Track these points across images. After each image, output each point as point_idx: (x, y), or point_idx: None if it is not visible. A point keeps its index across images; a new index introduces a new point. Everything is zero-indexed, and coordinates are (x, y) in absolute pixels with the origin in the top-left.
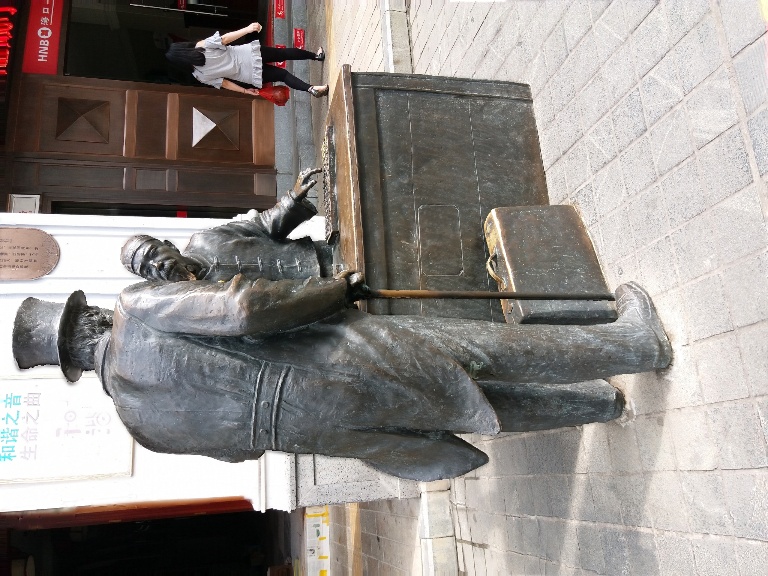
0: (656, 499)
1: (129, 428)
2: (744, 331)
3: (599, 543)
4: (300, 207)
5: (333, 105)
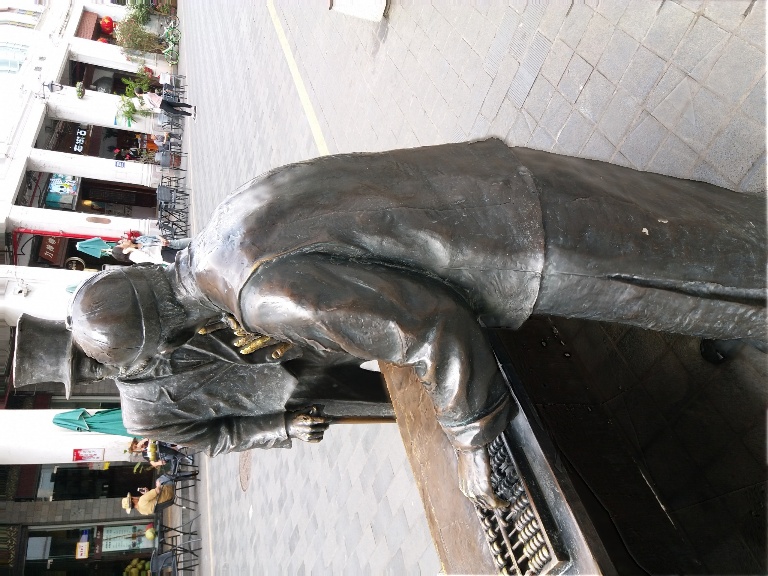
0: None
1: None
2: None
3: None
4: None
5: None
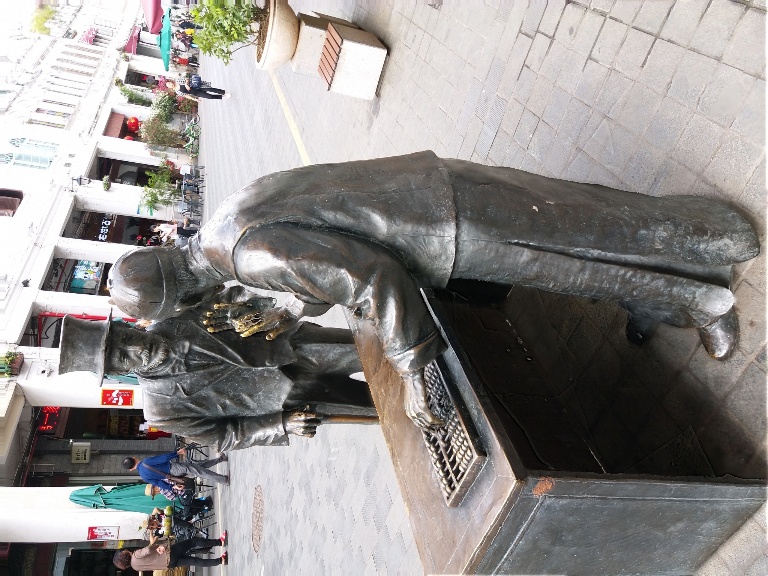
0: None
1: None
2: None
3: None
4: None
5: (462, 545)
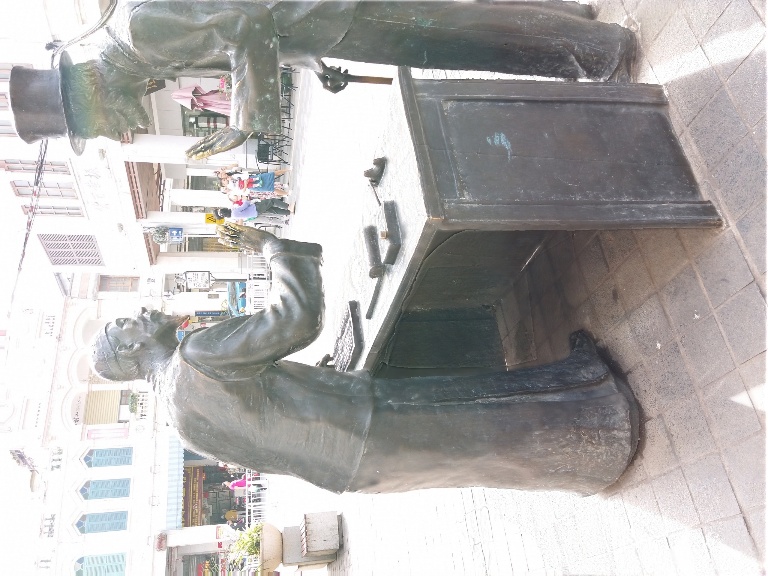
0: None
1: None
2: None
3: None
4: None
5: None
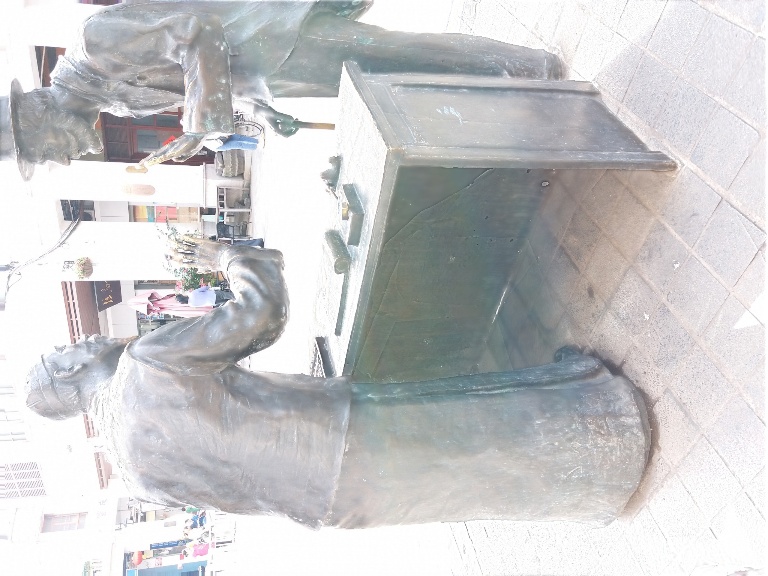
0: None
1: None
2: None
3: None
4: None
5: None
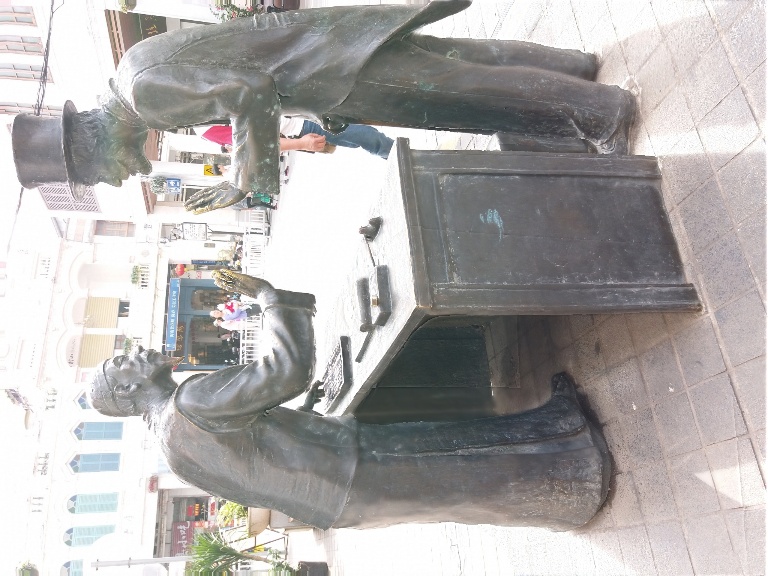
0: (676, 7)
1: (131, 48)
2: (573, 5)
3: (762, 67)
4: (308, 410)
5: None
